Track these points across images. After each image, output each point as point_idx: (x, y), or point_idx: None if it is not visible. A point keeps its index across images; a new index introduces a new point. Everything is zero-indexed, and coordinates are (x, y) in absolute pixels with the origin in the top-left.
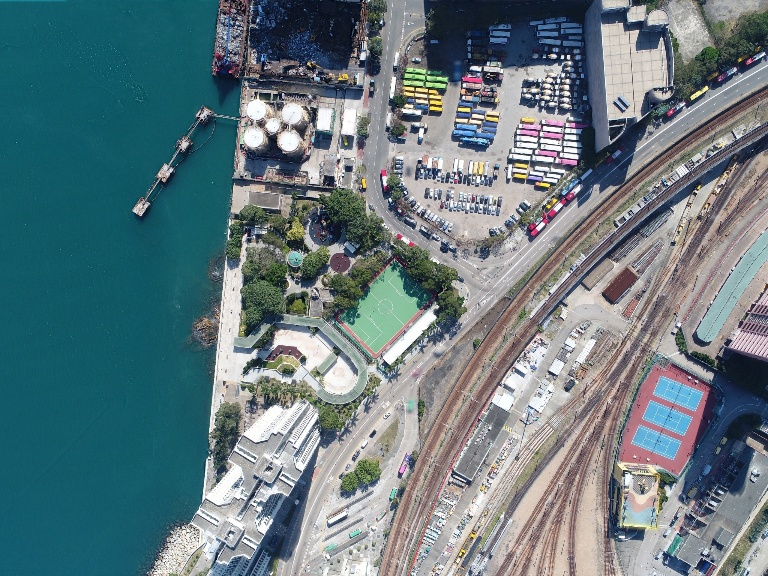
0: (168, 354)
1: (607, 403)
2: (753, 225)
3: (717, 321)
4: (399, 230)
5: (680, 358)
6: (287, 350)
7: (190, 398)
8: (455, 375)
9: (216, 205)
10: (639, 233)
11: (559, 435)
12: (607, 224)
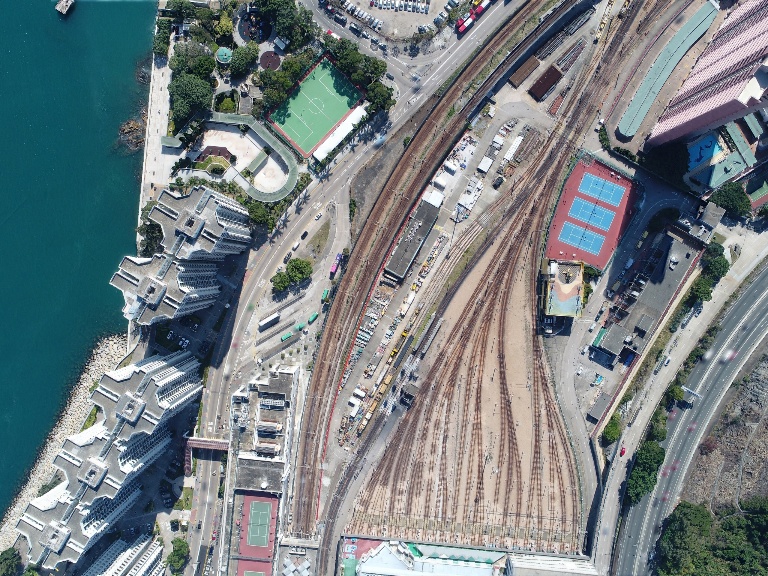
0: (94, 159)
1: (534, 200)
2: (670, 23)
3: (637, 116)
4: (329, 28)
5: (603, 155)
6: (217, 151)
7: (117, 203)
8: (386, 174)
9: (143, 4)
10: (563, 31)
11: (488, 233)
12: (533, 22)
